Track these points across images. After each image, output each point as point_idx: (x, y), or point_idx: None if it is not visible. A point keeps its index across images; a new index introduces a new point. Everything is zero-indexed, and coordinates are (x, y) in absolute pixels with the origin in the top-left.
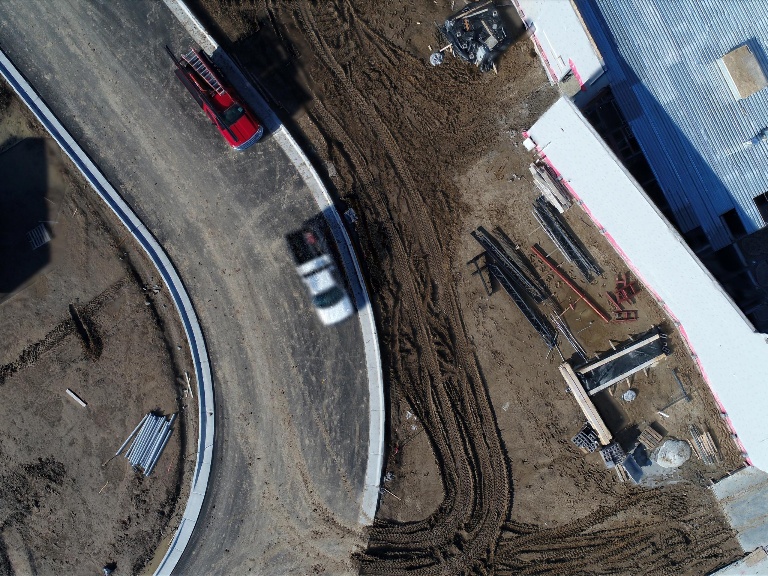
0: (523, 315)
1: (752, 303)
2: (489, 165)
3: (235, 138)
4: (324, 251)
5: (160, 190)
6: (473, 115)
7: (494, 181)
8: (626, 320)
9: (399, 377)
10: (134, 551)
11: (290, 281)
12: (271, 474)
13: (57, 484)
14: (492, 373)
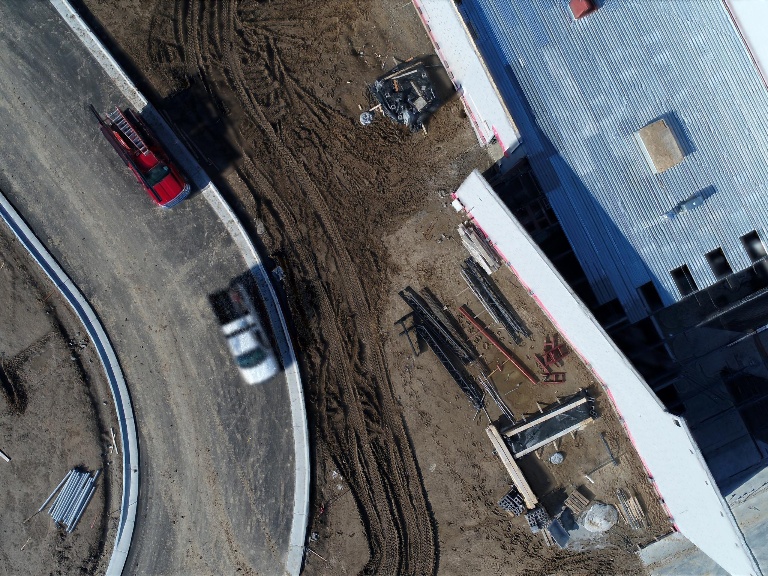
0: (450, 376)
1: (668, 376)
2: (418, 225)
3: (159, 198)
4: (251, 309)
5: (88, 245)
6: (402, 175)
7: (422, 241)
8: (554, 382)
9: (326, 436)
10: None
11: (217, 338)
12: (195, 532)
13: None
14: (419, 434)
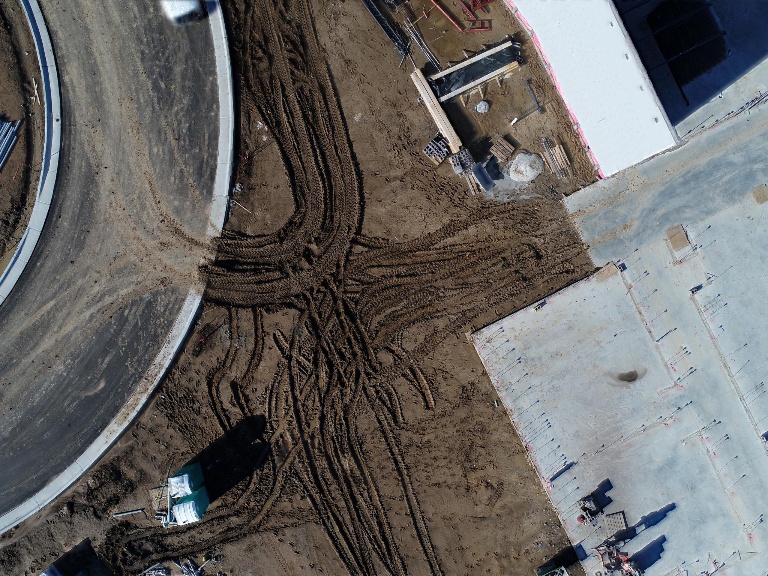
0: (376, 22)
1: None
2: None
3: None
4: None
5: None
6: None
7: None
8: (480, 30)
9: (250, 86)
10: None
11: None
12: (118, 184)
13: None
14: (344, 82)
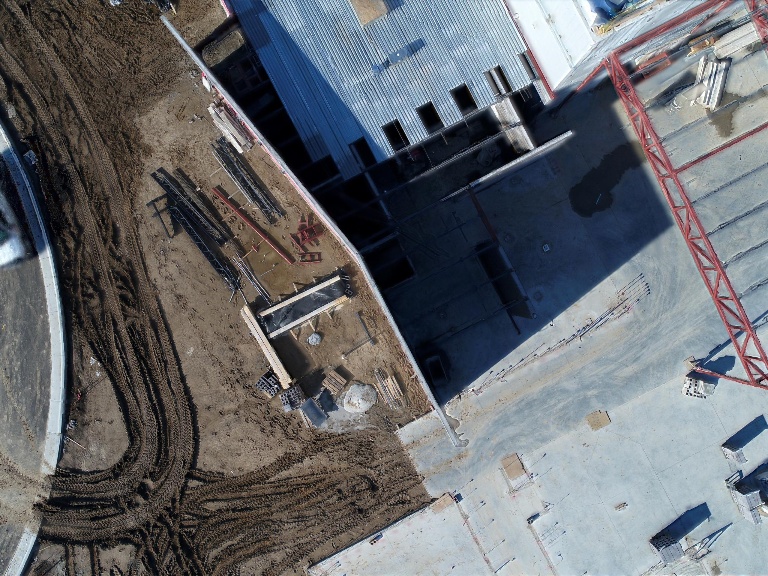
0: (205, 257)
1: (383, 233)
2: (170, 106)
3: None
4: (4, 193)
5: None
6: (153, 55)
7: (175, 122)
8: (310, 262)
9: (82, 322)
10: None
11: None
12: None
13: None
14: (175, 317)
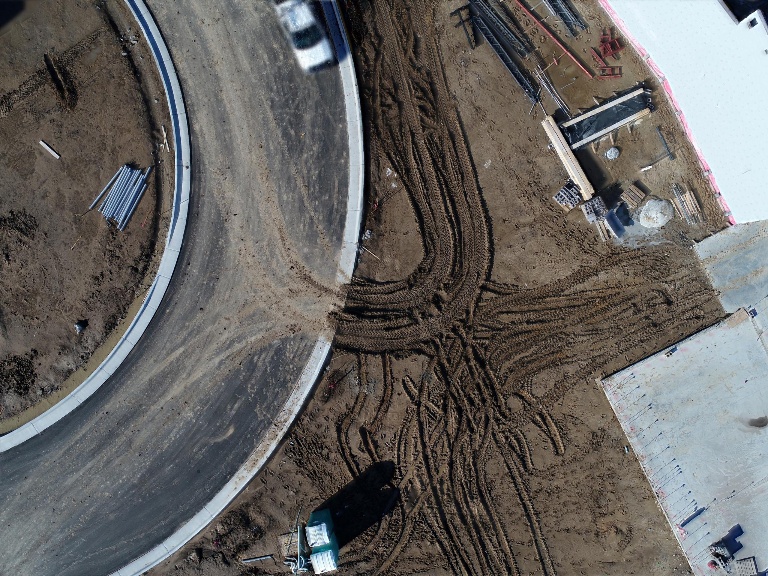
0: (506, 69)
1: None
2: None
3: None
4: (305, 2)
5: None
6: None
7: None
8: (610, 76)
9: (380, 133)
10: (106, 308)
11: (270, 32)
12: (248, 231)
13: (29, 238)
14: (474, 129)
